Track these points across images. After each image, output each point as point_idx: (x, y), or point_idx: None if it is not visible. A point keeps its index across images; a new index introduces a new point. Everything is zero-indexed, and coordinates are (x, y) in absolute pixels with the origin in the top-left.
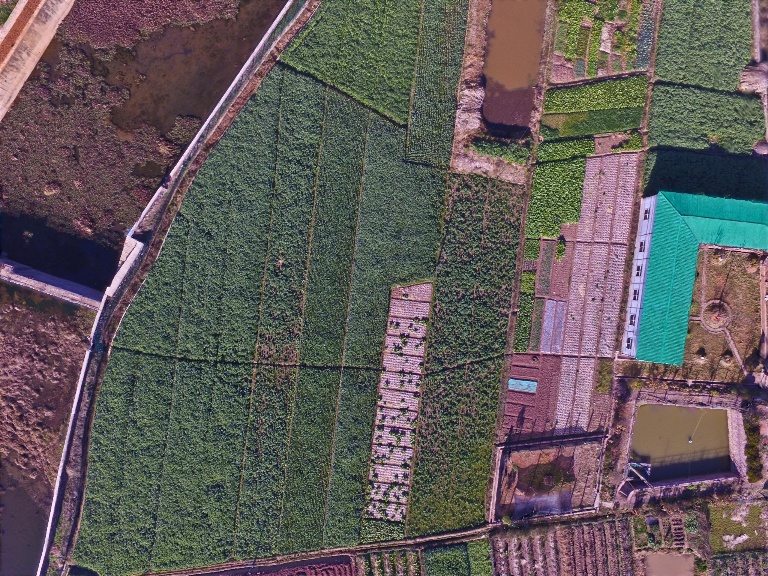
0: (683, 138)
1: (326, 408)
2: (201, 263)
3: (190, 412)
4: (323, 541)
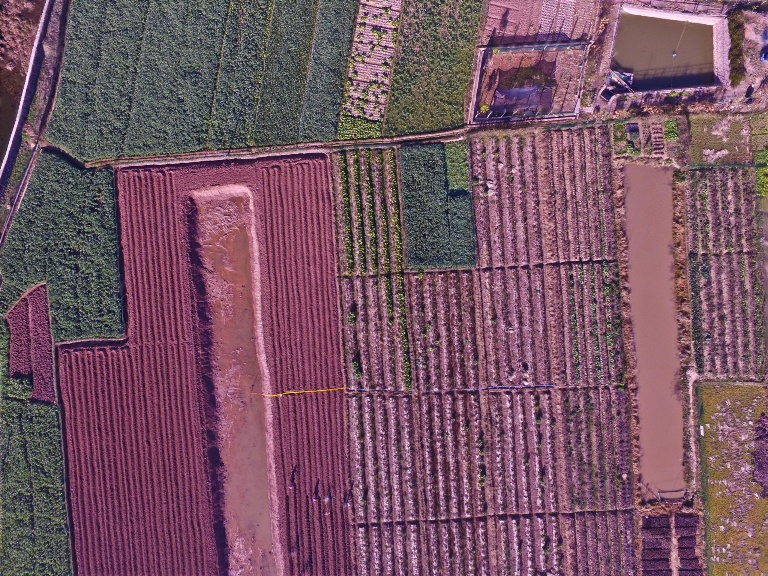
0: None
1: (308, 1)
2: None
3: None
4: (299, 134)
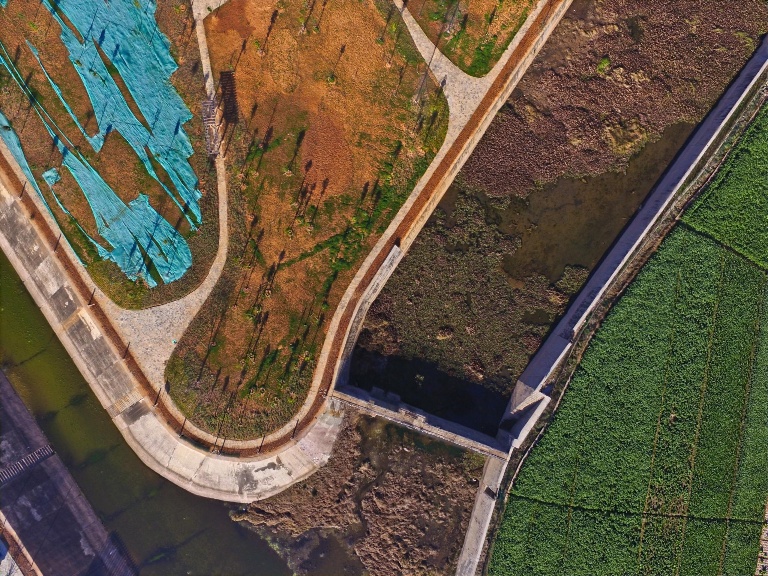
0: None
1: (711, 558)
2: (601, 416)
3: (585, 560)
4: None
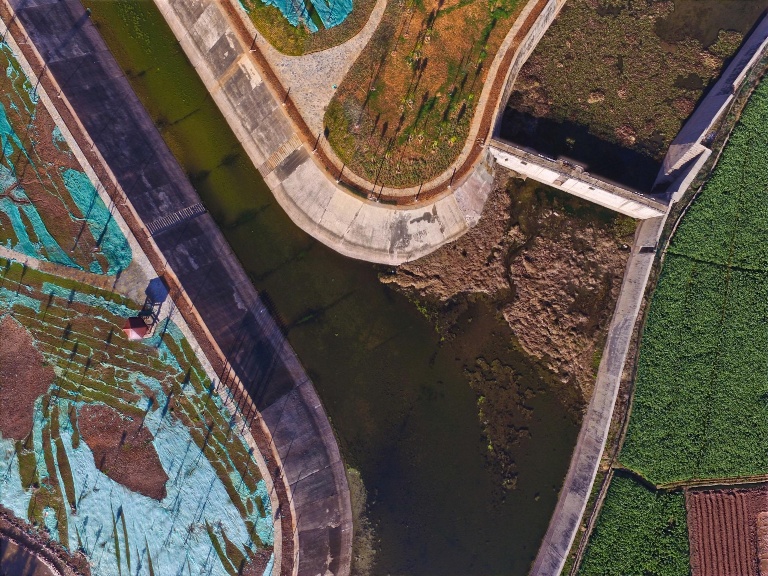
0: None
1: None
2: (762, 173)
3: (745, 321)
4: None
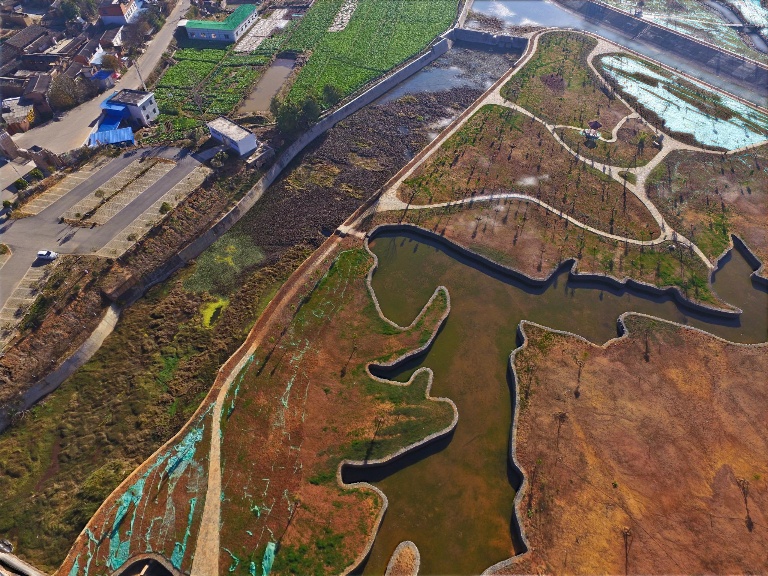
0: (212, 51)
1: None
2: None
3: None
4: None
